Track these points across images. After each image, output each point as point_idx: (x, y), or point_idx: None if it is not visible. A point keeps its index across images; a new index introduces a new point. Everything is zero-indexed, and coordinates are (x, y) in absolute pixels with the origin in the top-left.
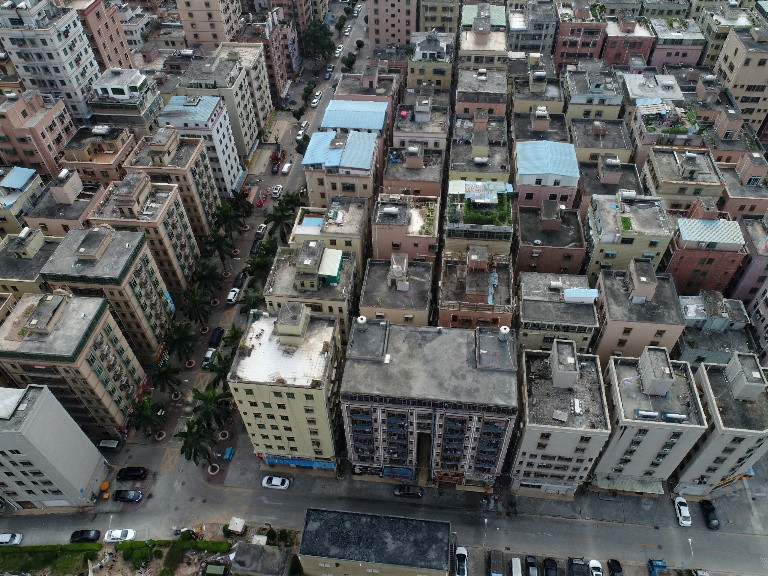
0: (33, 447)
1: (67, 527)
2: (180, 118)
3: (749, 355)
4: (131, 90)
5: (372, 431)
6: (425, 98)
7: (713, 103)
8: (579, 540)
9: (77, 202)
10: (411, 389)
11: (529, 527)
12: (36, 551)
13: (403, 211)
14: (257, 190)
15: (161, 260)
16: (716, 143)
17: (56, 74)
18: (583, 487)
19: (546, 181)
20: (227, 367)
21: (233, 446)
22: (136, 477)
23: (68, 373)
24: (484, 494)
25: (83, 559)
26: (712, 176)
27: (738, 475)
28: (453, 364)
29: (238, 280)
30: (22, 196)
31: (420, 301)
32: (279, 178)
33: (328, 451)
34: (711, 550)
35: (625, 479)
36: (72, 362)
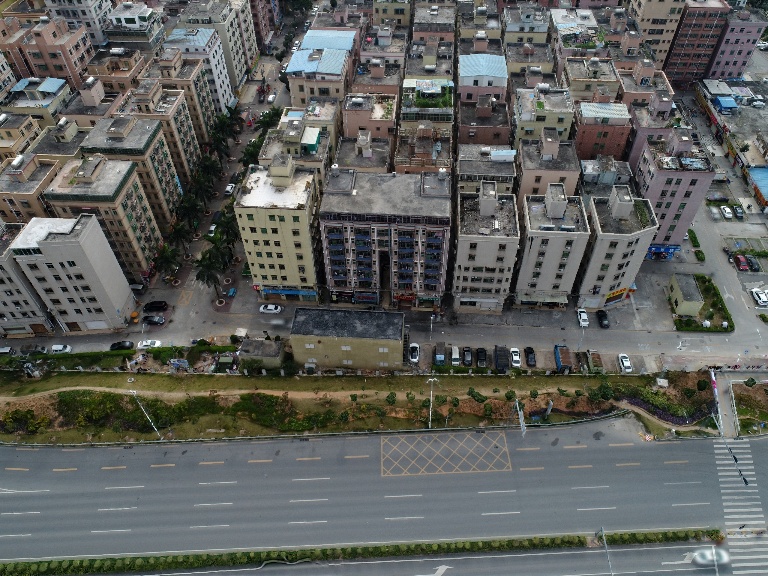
0: (86, 258)
1: (107, 342)
2: (182, 44)
3: (623, 186)
4: (141, 20)
5: (344, 252)
6: (386, 26)
7: (622, 31)
8: (504, 338)
9: (101, 105)
10: (372, 209)
11: (467, 331)
12: (84, 356)
13: (367, 102)
14: (247, 115)
15: (171, 152)
16: (620, 58)
17: (78, 5)
18: (509, 306)
19: (482, 82)
20: (230, 222)
21: (235, 288)
22: (159, 308)
23: (107, 215)
24: (433, 312)
25: (121, 360)
26: (611, 76)
27: (624, 289)
28: (404, 194)
29: (234, 178)
30: (56, 99)
31: (381, 163)
32: (265, 106)
33: (311, 279)
34: (602, 340)
35: (539, 294)
36: (112, 202)
